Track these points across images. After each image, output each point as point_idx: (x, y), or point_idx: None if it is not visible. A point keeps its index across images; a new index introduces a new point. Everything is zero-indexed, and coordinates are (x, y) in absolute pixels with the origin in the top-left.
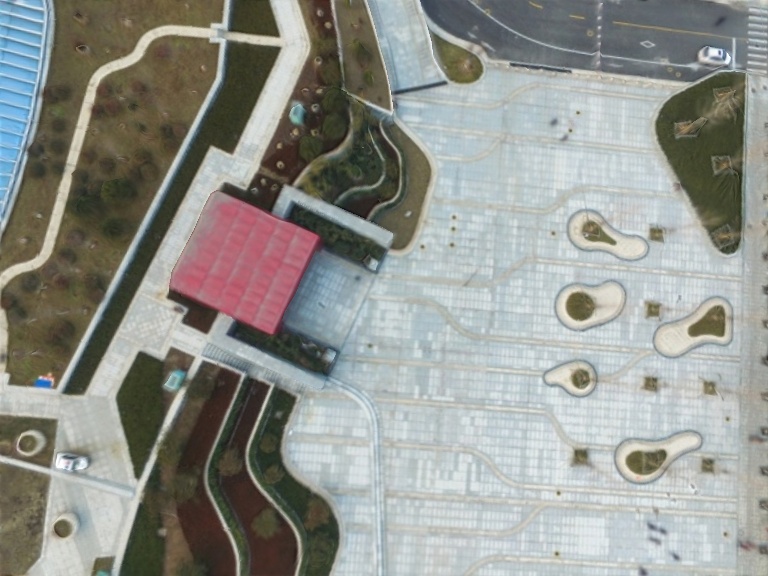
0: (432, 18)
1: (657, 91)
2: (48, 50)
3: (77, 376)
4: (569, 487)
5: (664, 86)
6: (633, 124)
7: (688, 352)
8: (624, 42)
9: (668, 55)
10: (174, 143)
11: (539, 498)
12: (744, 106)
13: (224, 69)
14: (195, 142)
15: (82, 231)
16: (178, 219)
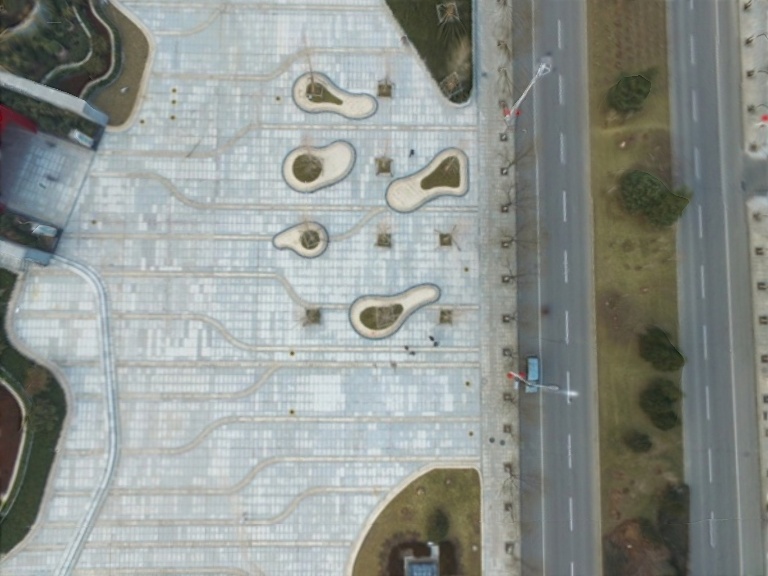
0: None
1: None
2: None
3: None
4: (303, 347)
5: None
6: None
7: (423, 206)
8: None
9: None
10: None
11: (272, 359)
12: None
13: None
14: None
15: None
16: None
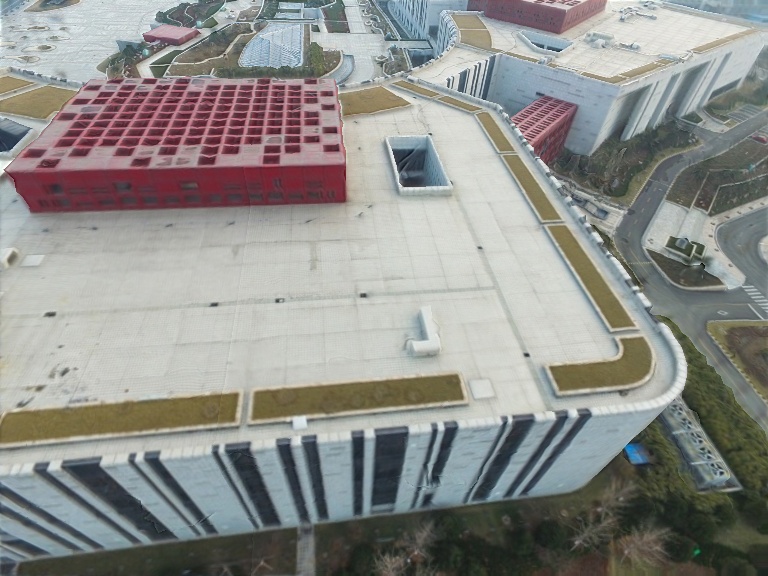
0: None
1: None
2: None
3: None
4: None
5: None
6: None
7: None
8: None
9: None
10: None
11: None
12: None
13: None
14: None
15: None
16: None
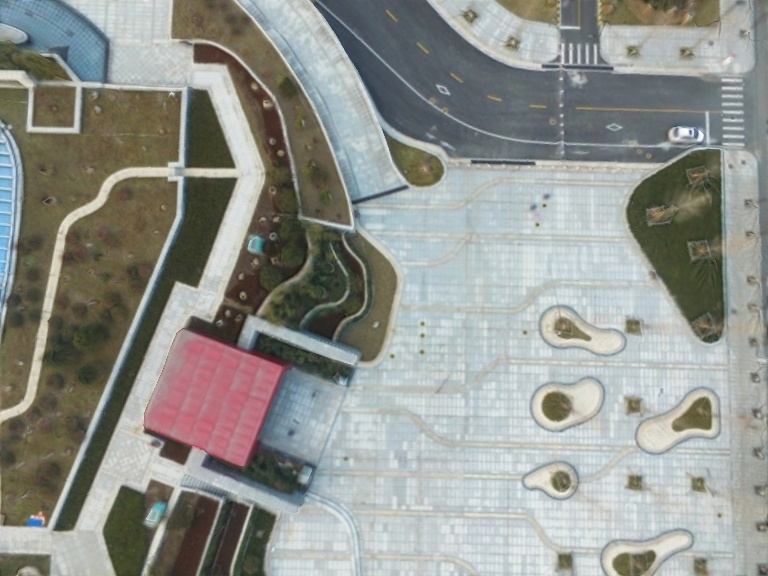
0: (389, 122)
1: (627, 176)
2: (19, 204)
3: (65, 513)
4: None
5: (634, 170)
6: (603, 212)
7: (673, 447)
8: (589, 128)
9: (637, 137)
10: (140, 283)
11: None
12: (720, 185)
13: (183, 206)
14: (161, 280)
15: (61, 375)
16: (150, 355)
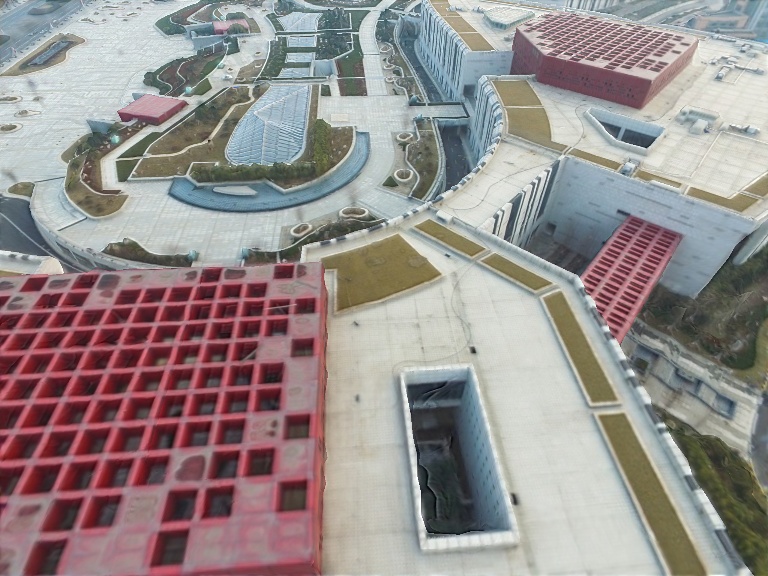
0: None
1: None
2: None
3: None
4: (47, 94)
5: None
6: None
7: None
8: None
9: None
10: None
11: None
12: None
13: None
14: None
15: (218, 110)
16: None
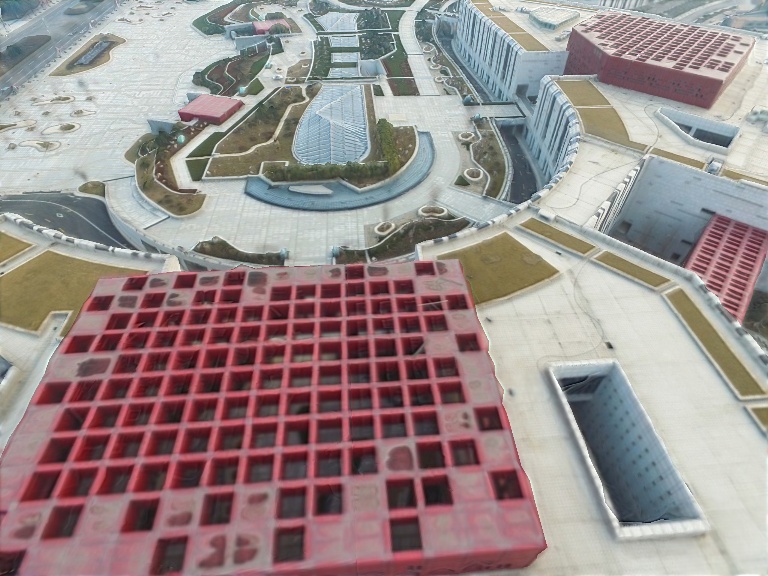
0: None
1: None
2: None
3: None
4: None
5: None
6: None
7: None
8: None
9: None
10: None
11: None
12: None
13: None
14: None
15: None
16: None
